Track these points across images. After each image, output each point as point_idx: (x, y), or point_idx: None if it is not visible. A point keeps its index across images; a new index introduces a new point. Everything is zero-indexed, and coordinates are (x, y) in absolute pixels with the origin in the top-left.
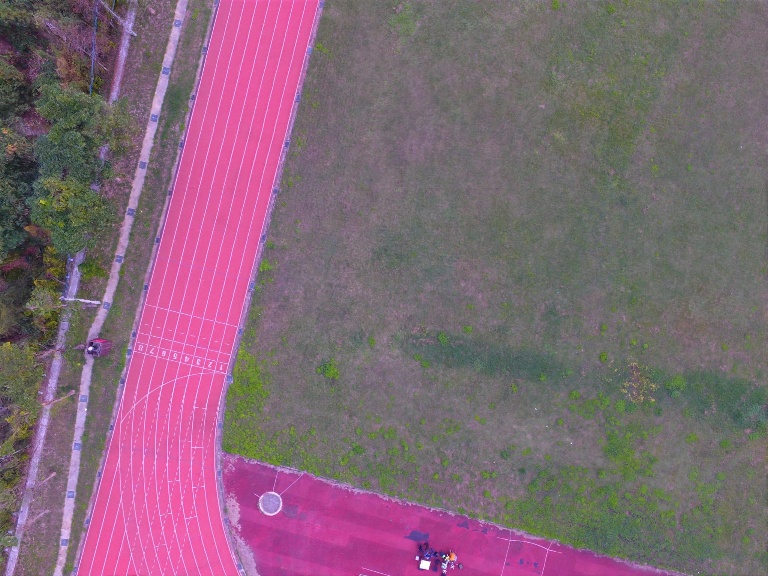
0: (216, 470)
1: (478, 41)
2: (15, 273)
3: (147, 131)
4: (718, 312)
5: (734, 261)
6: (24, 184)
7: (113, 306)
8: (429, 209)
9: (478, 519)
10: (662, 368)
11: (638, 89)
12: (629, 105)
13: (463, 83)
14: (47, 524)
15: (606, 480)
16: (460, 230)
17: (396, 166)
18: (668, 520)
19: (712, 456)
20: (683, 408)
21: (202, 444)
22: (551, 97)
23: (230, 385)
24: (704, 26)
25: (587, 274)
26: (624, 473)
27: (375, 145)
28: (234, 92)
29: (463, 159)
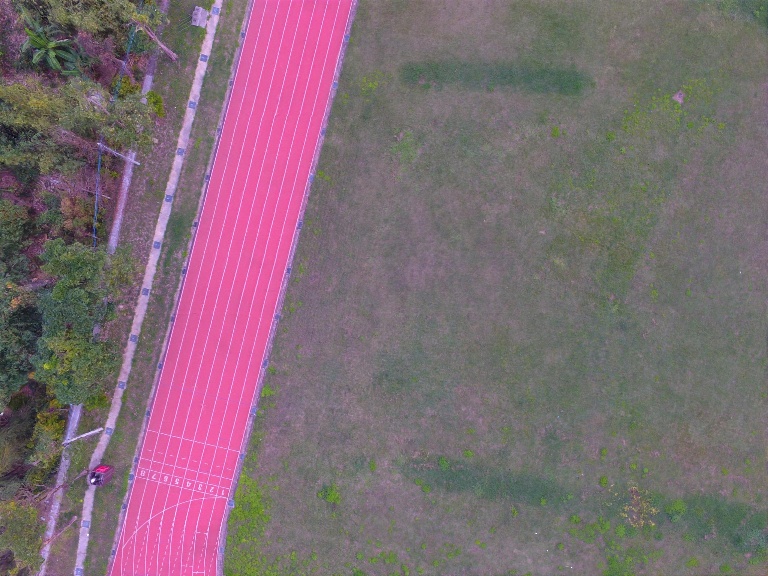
0: None
1: (479, 168)
2: (18, 400)
3: (150, 258)
4: (718, 436)
5: (734, 385)
6: (28, 333)
7: (115, 432)
8: (430, 334)
9: None
10: (662, 492)
11: (638, 215)
12: (629, 231)
13: (464, 210)
14: None
15: None
16: (461, 355)
17: (397, 292)
18: None
19: None
20: (683, 532)
21: (203, 569)
22: (551, 223)
23: (232, 510)
24: (703, 153)
25: (587, 399)
26: None
27: (376, 271)
28: (236, 219)
29: (464, 285)
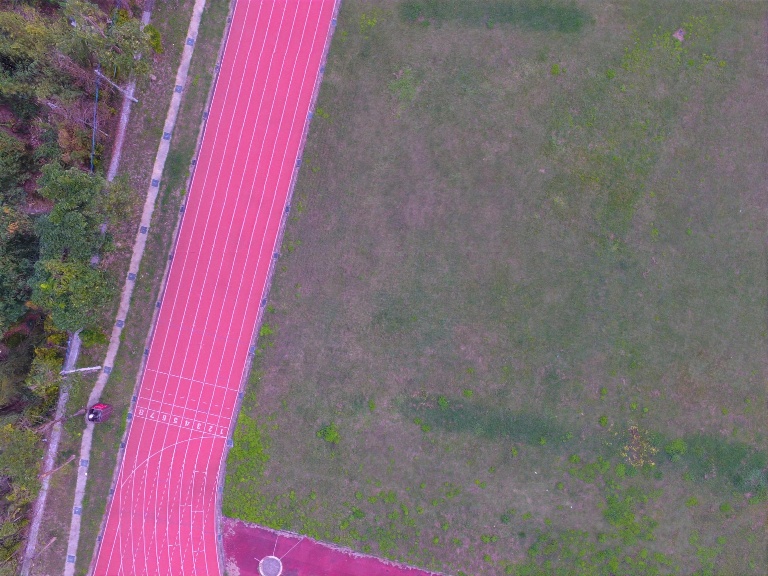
0: (216, 534)
1: (478, 106)
2: (16, 338)
3: (148, 196)
4: (718, 376)
5: (734, 325)
6: (25, 260)
7: (114, 371)
8: (429, 273)
9: None
10: (662, 432)
11: (638, 153)
12: (629, 169)
13: (463, 148)
14: None
15: (606, 544)
16: (460, 294)
17: (396, 230)
18: None
19: (712, 520)
20: (683, 472)
21: (202, 508)
22: (551, 162)
23: (230, 449)
24: (703, 91)
25: (587, 338)
26: (624, 537)
27: (375, 210)
28: (235, 157)
29: (463, 223)
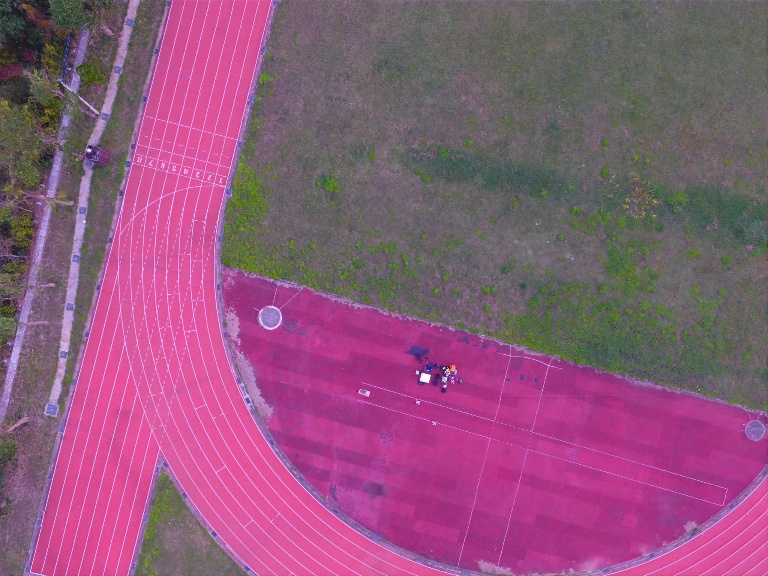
0: (215, 284)
1: None
2: (13, 82)
3: None
4: (720, 127)
5: (737, 76)
6: None
7: (112, 117)
8: (430, 21)
9: (478, 334)
10: (664, 184)
11: None
12: None
13: None
14: (46, 336)
15: (607, 296)
16: (461, 43)
17: None
18: (669, 336)
19: (714, 272)
20: (685, 224)
21: (201, 257)
22: None
23: (229, 198)
24: None
25: (589, 88)
26: (625, 289)
27: None
28: None
29: None
